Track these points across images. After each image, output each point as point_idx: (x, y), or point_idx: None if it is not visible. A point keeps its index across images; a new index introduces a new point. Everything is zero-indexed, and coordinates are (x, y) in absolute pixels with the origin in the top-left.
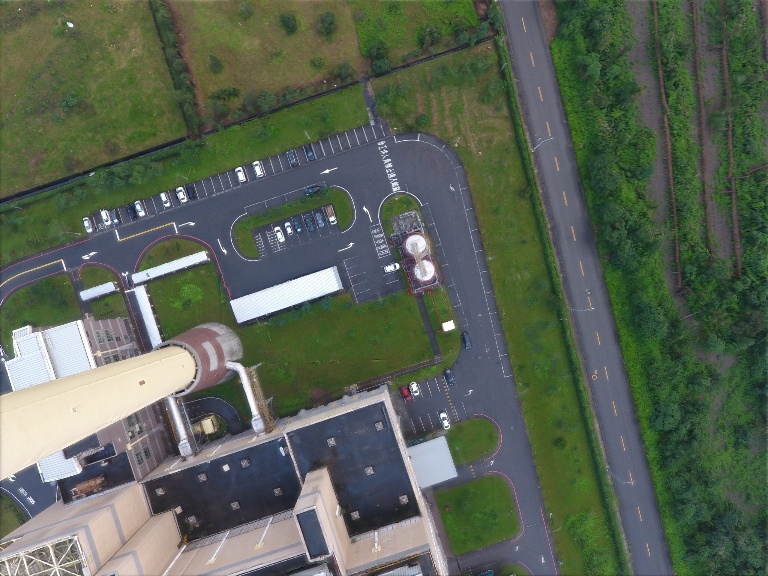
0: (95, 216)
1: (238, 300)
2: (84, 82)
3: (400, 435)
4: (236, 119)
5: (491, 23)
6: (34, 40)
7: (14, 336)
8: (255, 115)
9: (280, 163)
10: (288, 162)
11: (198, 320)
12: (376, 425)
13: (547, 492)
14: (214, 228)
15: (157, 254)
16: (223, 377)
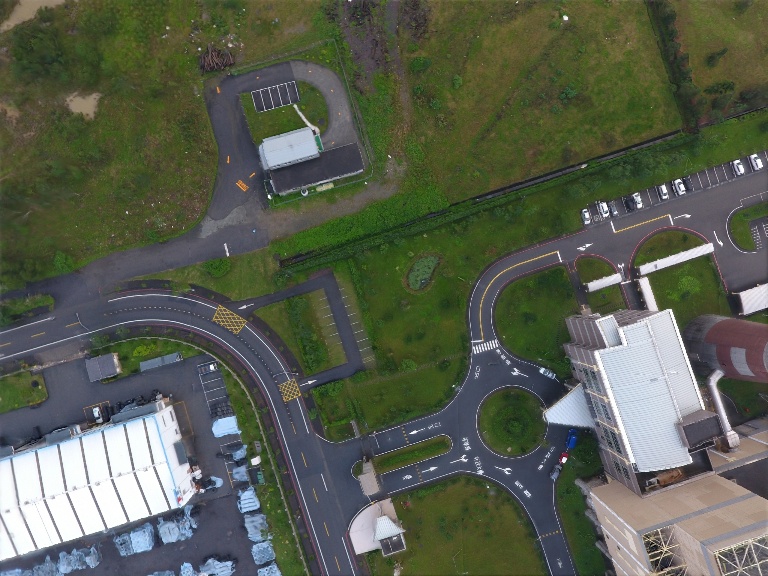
0: (591, 208)
1: (748, 292)
2: (581, 75)
3: None
4: (734, 112)
5: None
6: (529, 33)
7: (600, 325)
8: (750, 109)
9: None
10: None
11: (696, 312)
12: None
13: None
14: (710, 220)
15: (655, 246)
16: None
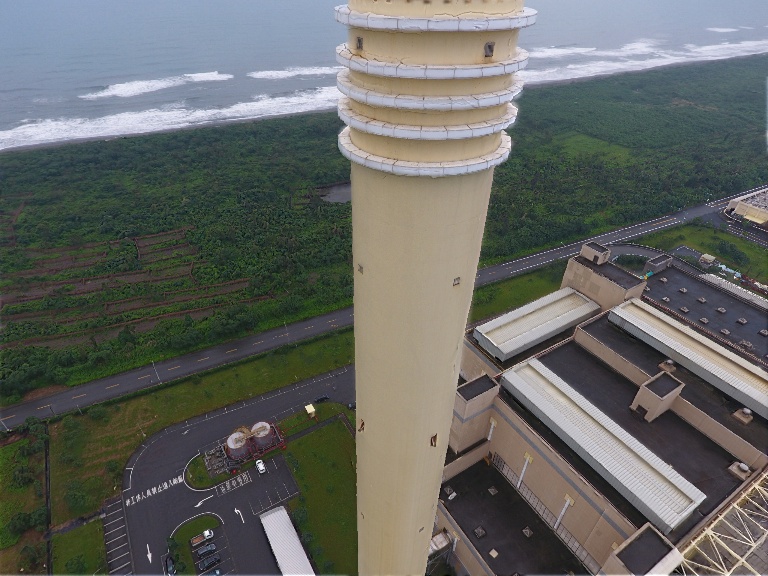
0: None
1: None
2: None
3: None
4: None
5: None
6: None
7: None
8: None
9: None
10: None
11: None
12: None
13: None
14: None
15: None
16: None
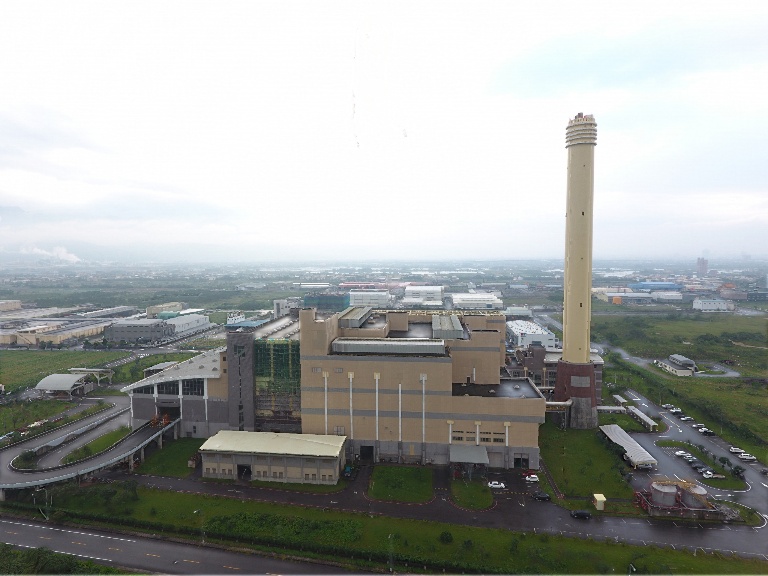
0: None
1: None
2: None
3: (507, 423)
4: None
5: None
6: None
7: None
8: None
9: None
10: None
11: None
12: None
13: (396, 520)
14: None
15: None
16: None
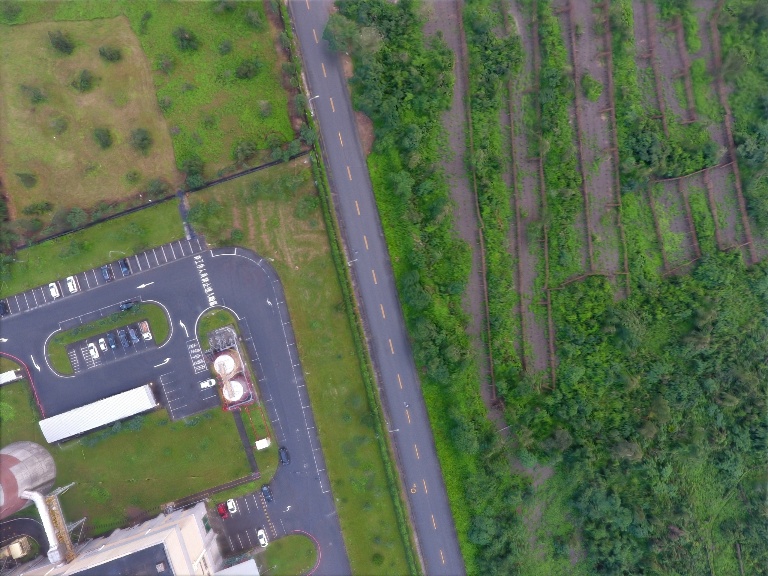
0: None
1: (47, 420)
2: None
3: (195, 568)
4: (49, 234)
5: (303, 140)
6: None
7: None
8: (70, 229)
9: (95, 278)
10: (103, 277)
11: (10, 439)
12: (156, 567)
13: None
14: (27, 344)
15: None
16: (23, 505)
